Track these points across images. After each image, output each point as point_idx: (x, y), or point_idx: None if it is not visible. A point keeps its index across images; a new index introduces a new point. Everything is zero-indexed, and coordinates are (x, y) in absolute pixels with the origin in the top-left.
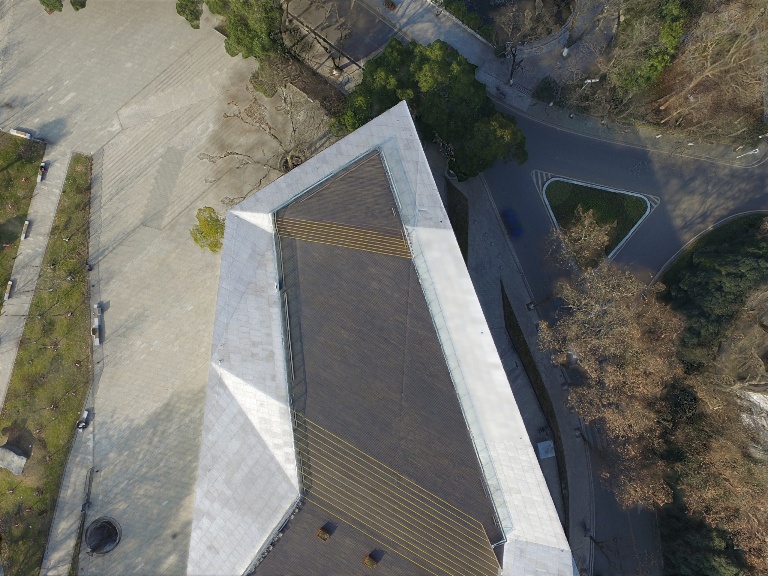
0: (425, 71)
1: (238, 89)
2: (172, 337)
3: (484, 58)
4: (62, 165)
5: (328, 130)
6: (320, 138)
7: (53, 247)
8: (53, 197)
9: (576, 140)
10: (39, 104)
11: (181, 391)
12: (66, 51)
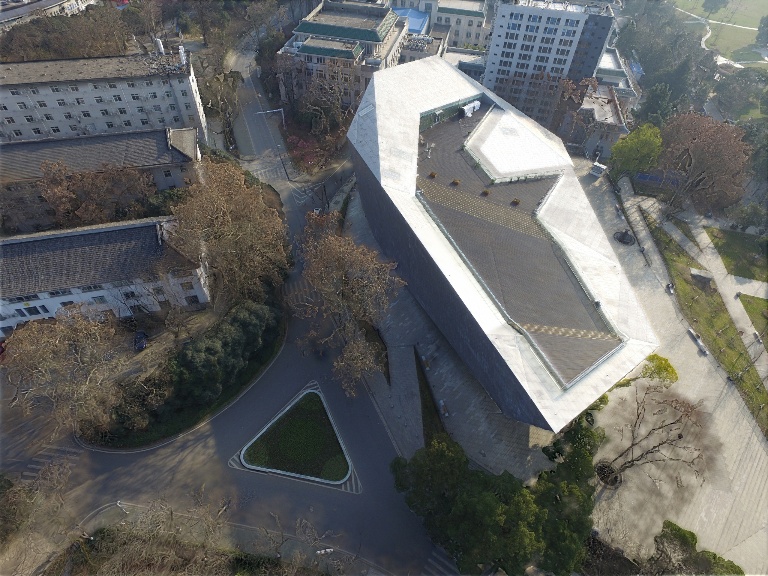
0: None
1: None
2: None
3: None
4: None
5: None
6: None
7: None
8: None
9: None
10: None
11: None
12: None
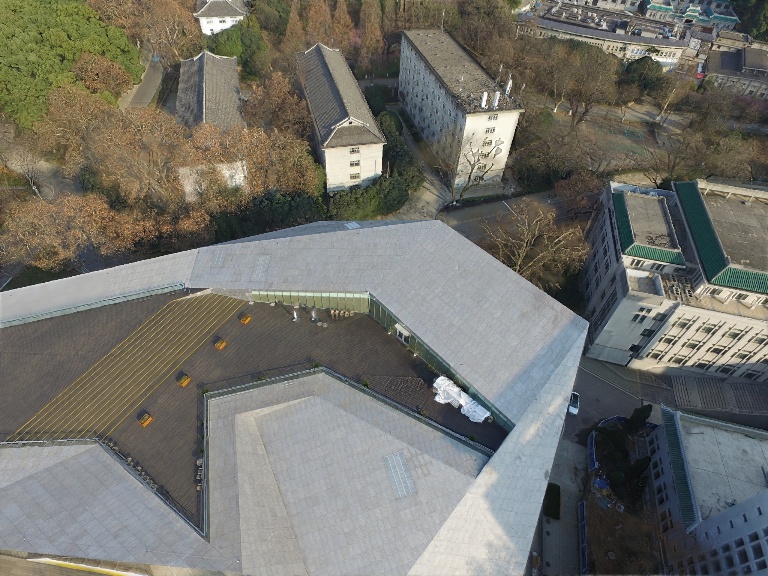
0: None
1: None
2: None
3: None
4: None
5: None
6: None
7: None
8: None
9: None
10: None
11: None
12: None
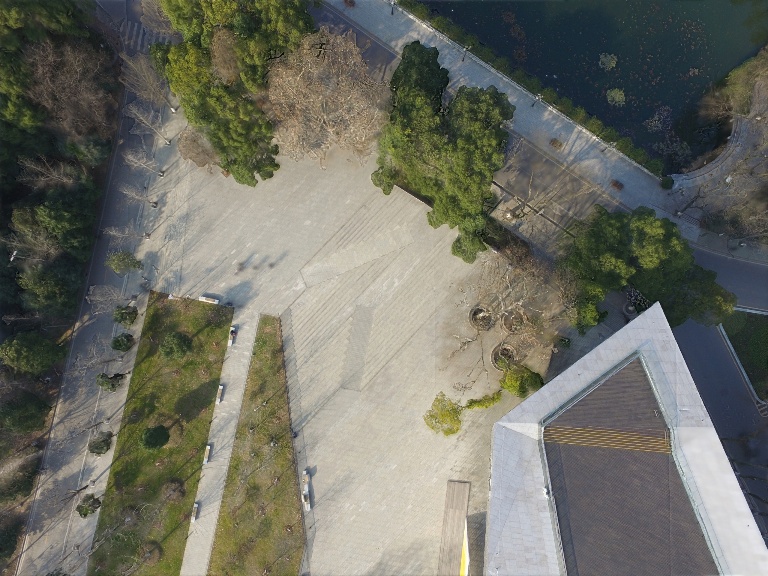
0: (651, 252)
1: (419, 242)
2: (379, 497)
3: (651, 190)
4: (251, 328)
5: (513, 279)
6: (506, 288)
7: (249, 410)
8: (244, 360)
9: (747, 267)
10: (224, 268)
11: (392, 549)
12: (246, 213)
